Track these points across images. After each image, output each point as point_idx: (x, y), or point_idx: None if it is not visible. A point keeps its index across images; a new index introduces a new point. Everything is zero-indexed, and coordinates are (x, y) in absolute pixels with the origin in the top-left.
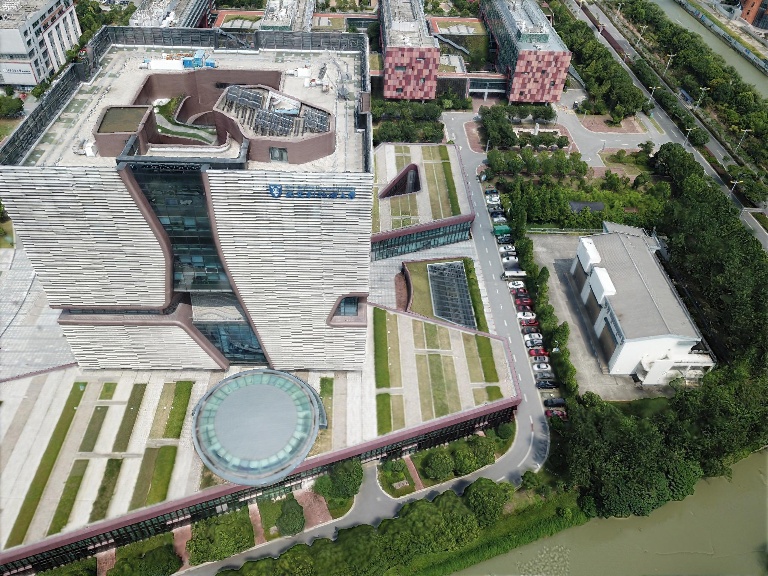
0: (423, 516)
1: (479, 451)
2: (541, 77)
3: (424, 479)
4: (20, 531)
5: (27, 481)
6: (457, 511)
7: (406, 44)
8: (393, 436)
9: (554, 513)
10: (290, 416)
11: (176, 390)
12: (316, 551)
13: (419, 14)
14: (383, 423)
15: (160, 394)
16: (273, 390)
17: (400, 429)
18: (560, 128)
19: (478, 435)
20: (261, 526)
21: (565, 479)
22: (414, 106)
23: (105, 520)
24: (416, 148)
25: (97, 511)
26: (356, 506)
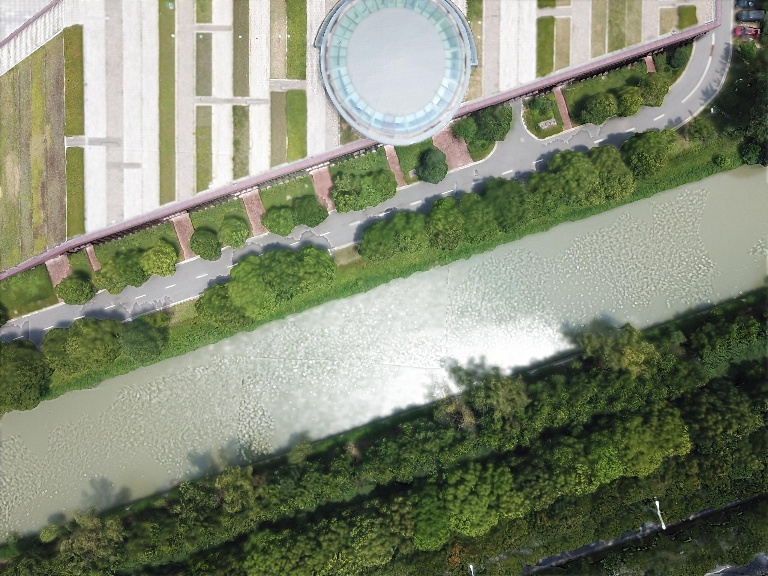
0: (578, 175)
1: (649, 94)
2: None
3: (574, 118)
4: (169, 187)
5: (154, 131)
6: (616, 171)
7: None
8: (554, 78)
9: (709, 159)
10: (436, 56)
11: (288, 10)
12: (466, 209)
13: None
14: (544, 61)
15: (269, 15)
16: (413, 17)
17: (563, 68)
18: None
19: (645, 61)
20: (400, 169)
21: (735, 124)
22: None
23: (250, 177)
24: None
25: (239, 167)
26: (498, 148)
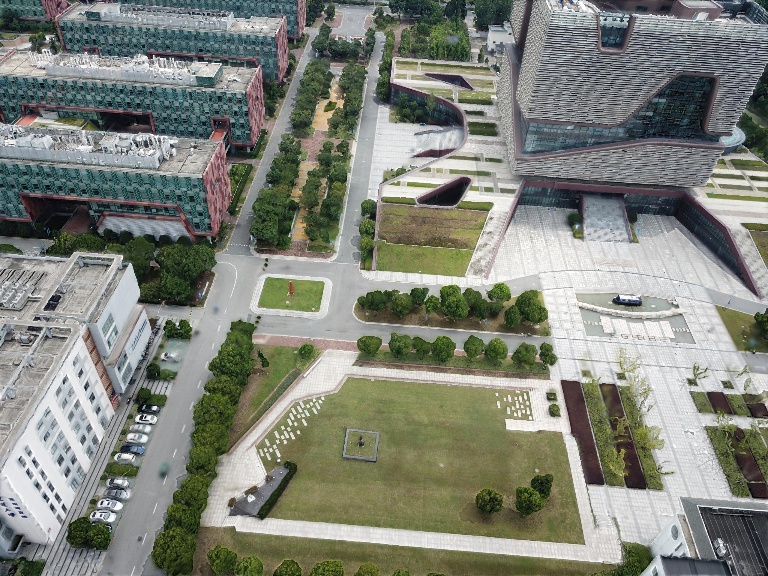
0: None
1: None
2: (302, 8)
3: None
4: None
5: None
6: None
7: (266, 28)
8: None
9: None
10: None
11: None
12: (752, 129)
13: (186, 15)
14: None
15: None
16: None
17: None
18: (333, 35)
19: None
20: None
21: None
22: (316, 68)
23: None
24: (398, 71)
25: None
26: None
